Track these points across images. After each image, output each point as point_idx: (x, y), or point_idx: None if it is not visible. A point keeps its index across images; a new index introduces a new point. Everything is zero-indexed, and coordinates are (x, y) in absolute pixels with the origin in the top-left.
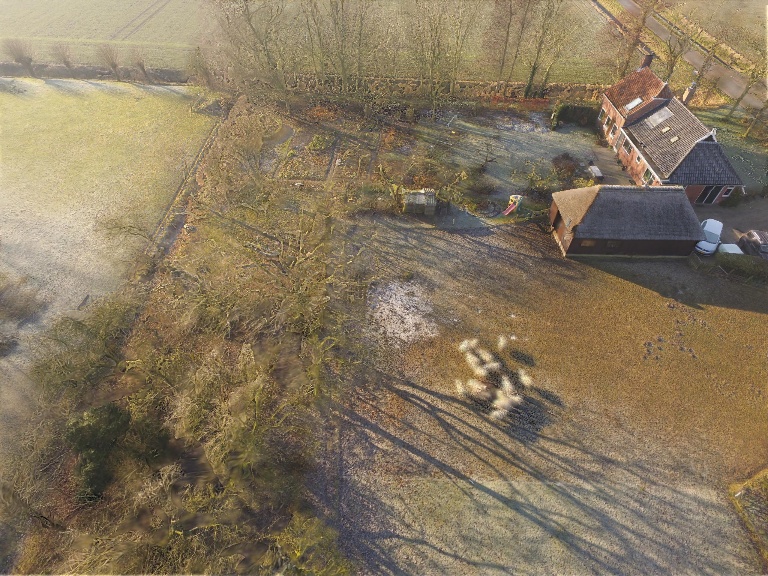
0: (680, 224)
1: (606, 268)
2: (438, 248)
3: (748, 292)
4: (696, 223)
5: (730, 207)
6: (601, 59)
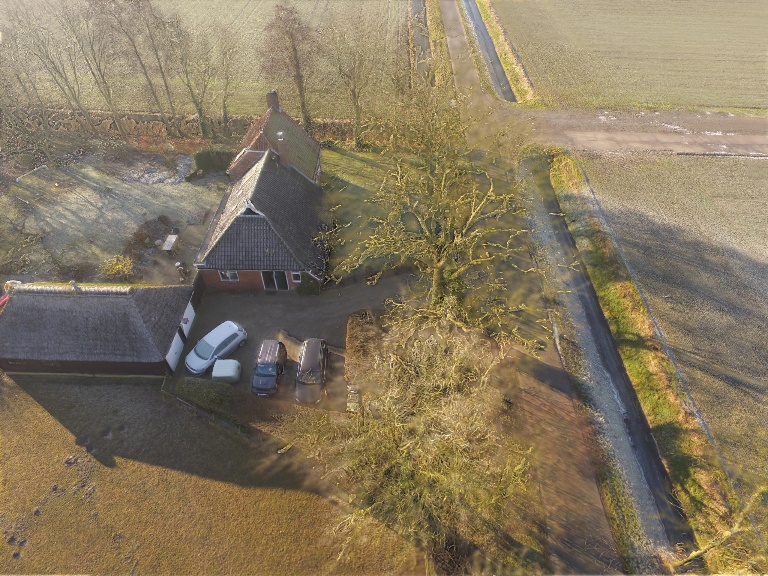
0: (124, 340)
1: (43, 394)
2: None
3: (206, 436)
4: (145, 339)
5: (310, 295)
6: None
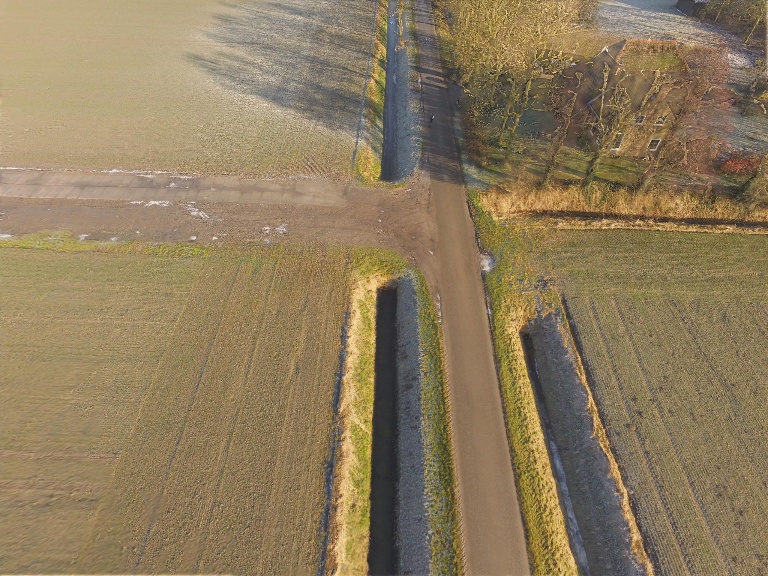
0: None
1: None
2: (737, 77)
3: None
4: None
5: None
6: (667, 298)
